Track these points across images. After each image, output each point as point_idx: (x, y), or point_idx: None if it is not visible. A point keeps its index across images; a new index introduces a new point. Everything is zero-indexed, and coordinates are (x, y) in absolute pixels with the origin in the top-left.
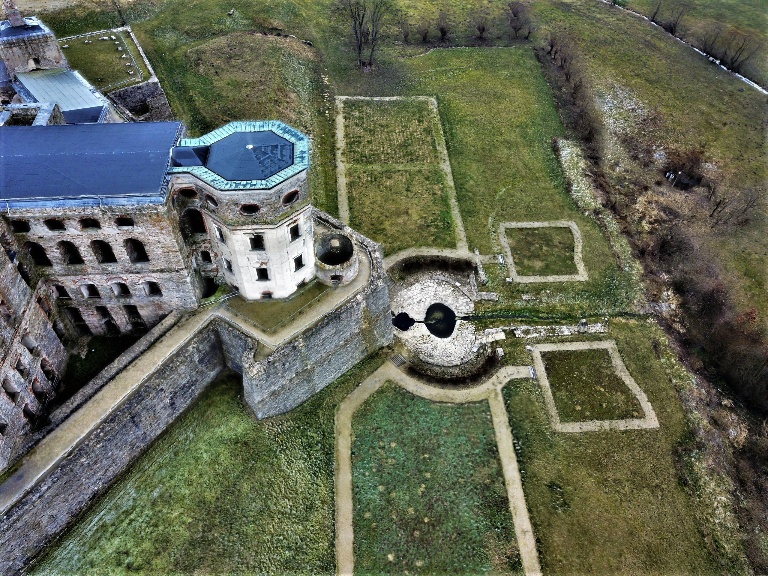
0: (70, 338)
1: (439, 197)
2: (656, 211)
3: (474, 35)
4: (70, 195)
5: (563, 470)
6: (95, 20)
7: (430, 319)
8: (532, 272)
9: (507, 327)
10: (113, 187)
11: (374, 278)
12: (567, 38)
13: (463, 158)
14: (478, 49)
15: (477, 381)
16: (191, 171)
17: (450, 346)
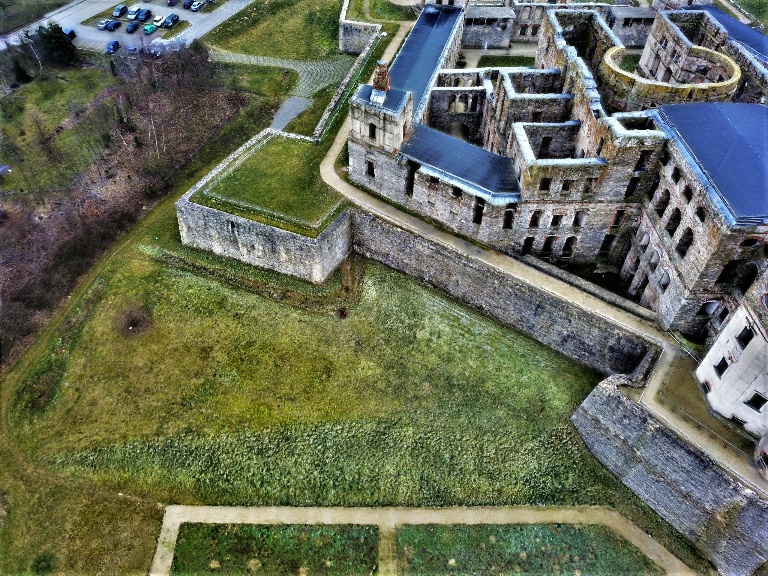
0: (609, 257)
1: None
2: None
3: None
4: (703, 164)
5: None
6: None
7: None
8: None
9: None
10: (728, 186)
11: None
12: None
13: None
14: None
15: None
16: None
17: None
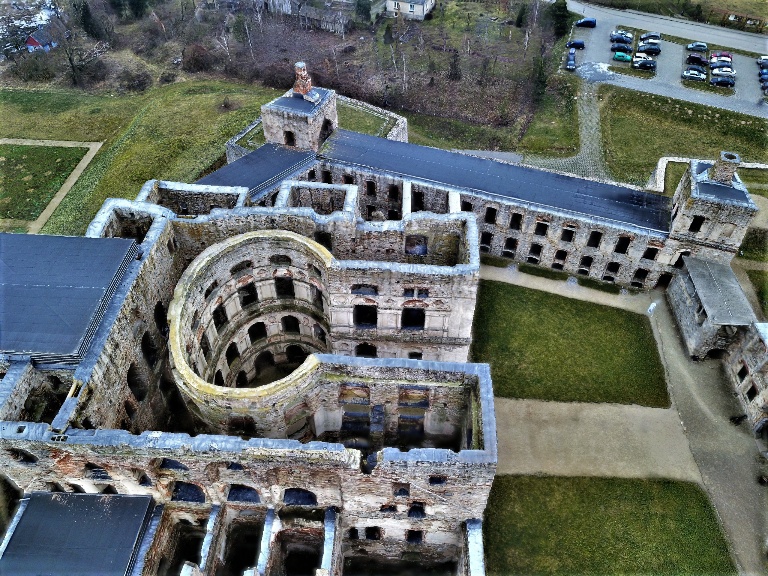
0: None
1: None
2: None
3: None
4: None
5: None
6: None
7: None
8: None
9: None
10: None
11: None
12: None
13: None
14: None
15: None
16: None
17: None
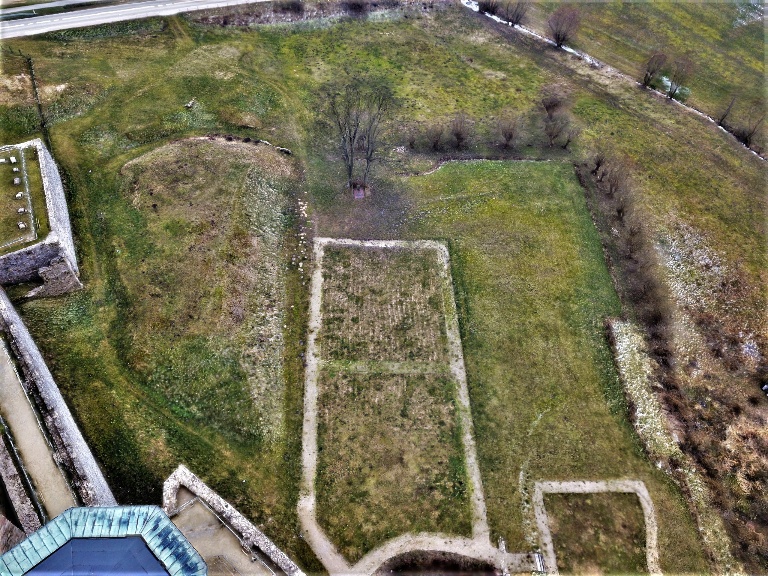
0: None
1: (448, 430)
2: (755, 454)
3: (498, 140)
4: None
5: None
6: (5, 119)
7: None
8: None
9: None
10: None
11: None
12: (615, 148)
13: (483, 354)
14: (503, 164)
15: None
16: None
17: None
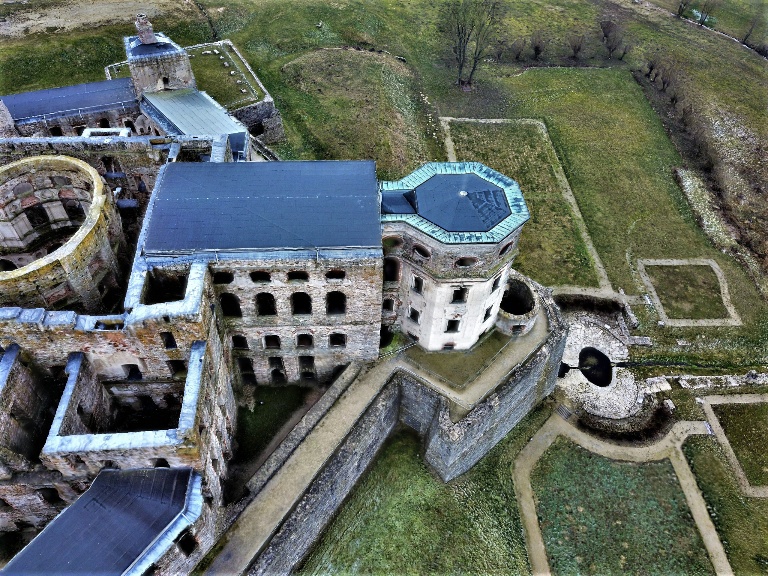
0: (236, 389)
1: (570, 230)
2: None
3: (566, 54)
4: (285, 246)
5: (767, 541)
6: (186, 31)
7: (584, 365)
8: (683, 315)
9: (670, 376)
10: (329, 238)
11: (555, 328)
12: (662, 60)
13: (585, 187)
14: (575, 69)
15: (653, 437)
16: (407, 220)
17: (612, 396)
